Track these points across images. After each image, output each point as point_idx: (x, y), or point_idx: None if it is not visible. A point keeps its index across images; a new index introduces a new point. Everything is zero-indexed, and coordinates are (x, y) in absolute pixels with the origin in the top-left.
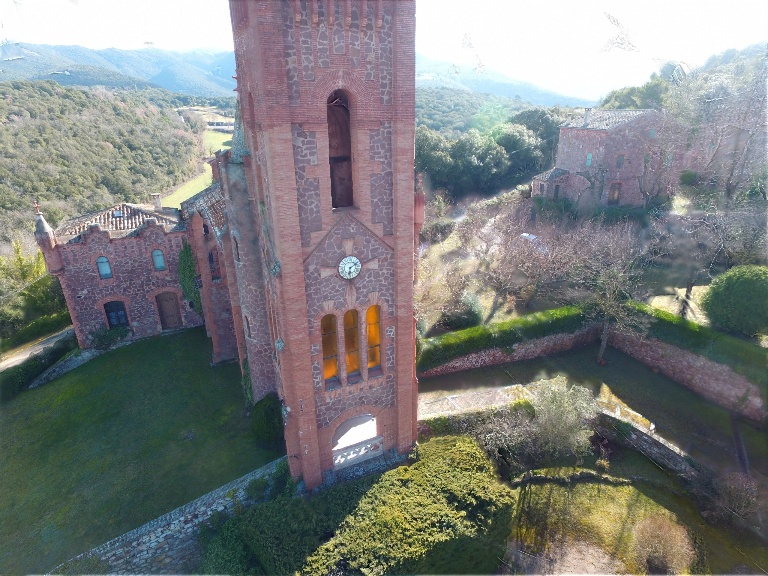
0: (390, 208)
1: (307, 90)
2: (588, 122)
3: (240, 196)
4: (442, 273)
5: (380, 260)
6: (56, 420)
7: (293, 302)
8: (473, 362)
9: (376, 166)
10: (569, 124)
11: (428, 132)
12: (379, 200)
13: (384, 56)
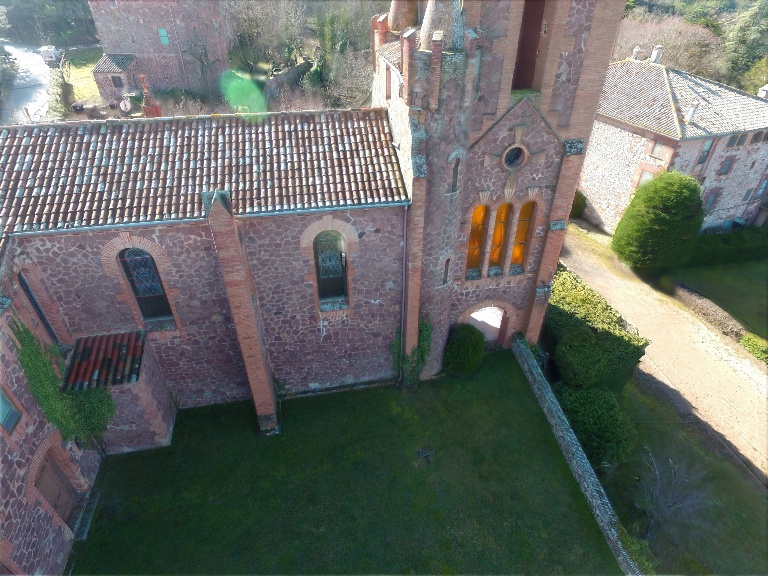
0: None
1: None
2: None
3: None
4: None
5: None
6: None
7: None
8: None
9: None
10: None
11: None
12: None
13: None
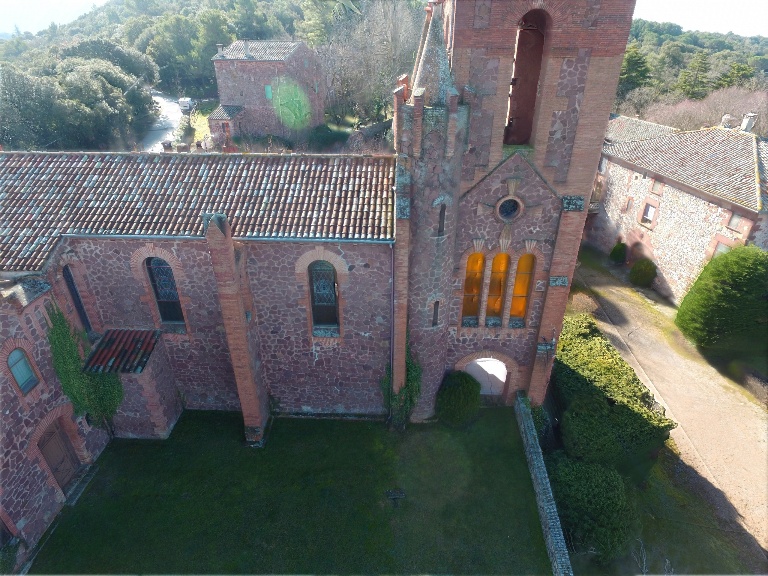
0: None
1: None
2: (249, 53)
3: (460, 148)
4: None
5: None
6: None
7: None
8: None
9: None
10: (224, 56)
11: None
12: None
13: None
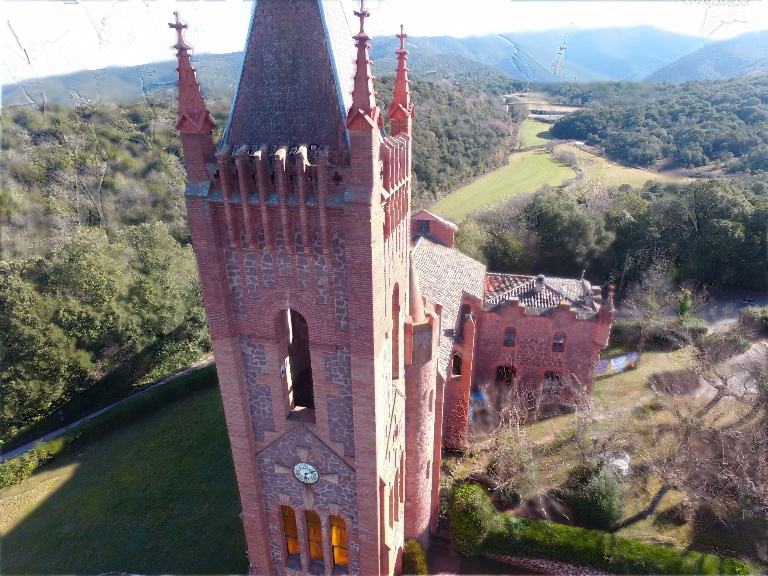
0: (353, 431)
1: (253, 307)
2: None
3: None
4: (631, 406)
5: (342, 477)
6: (209, 426)
7: (244, 486)
8: (569, 573)
9: (333, 388)
10: None
11: (719, 189)
12: (339, 420)
13: (340, 281)
